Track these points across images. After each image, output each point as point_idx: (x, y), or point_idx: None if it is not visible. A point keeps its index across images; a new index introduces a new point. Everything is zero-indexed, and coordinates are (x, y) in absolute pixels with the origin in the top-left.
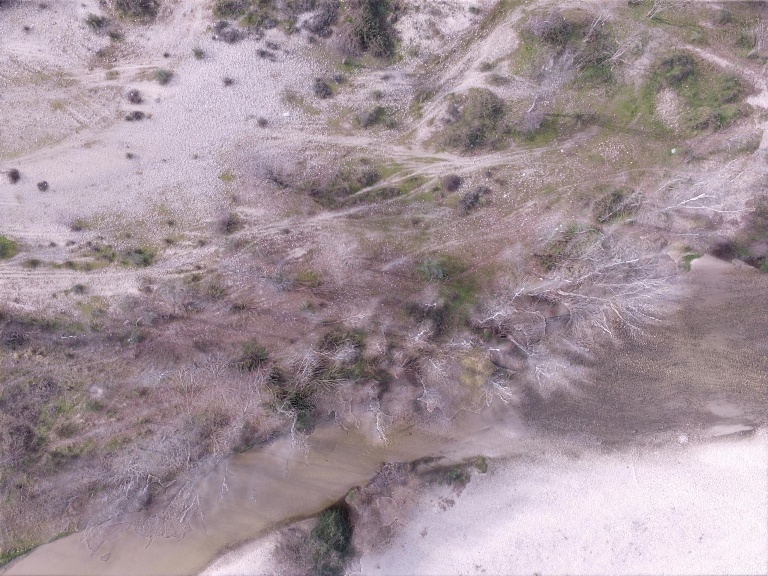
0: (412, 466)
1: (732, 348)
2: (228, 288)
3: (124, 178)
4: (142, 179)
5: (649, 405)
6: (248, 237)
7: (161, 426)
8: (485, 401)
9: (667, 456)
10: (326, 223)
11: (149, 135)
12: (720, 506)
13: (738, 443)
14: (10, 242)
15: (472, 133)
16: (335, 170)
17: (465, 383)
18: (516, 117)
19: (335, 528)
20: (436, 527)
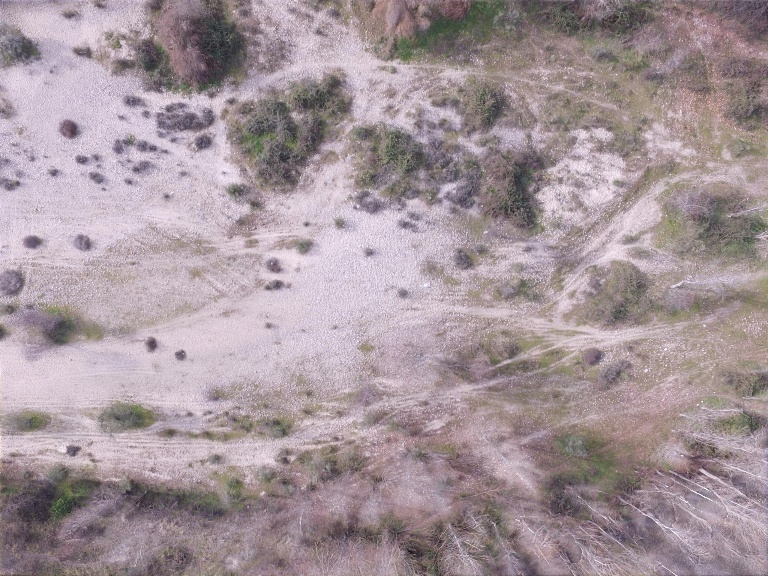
0: None
1: None
2: (365, 459)
3: (262, 348)
4: (281, 349)
5: None
6: (386, 408)
7: None
8: None
9: None
10: (465, 395)
11: (288, 305)
12: None
13: None
14: (147, 411)
15: (616, 310)
16: (475, 342)
17: None
18: (659, 291)
19: None
20: None
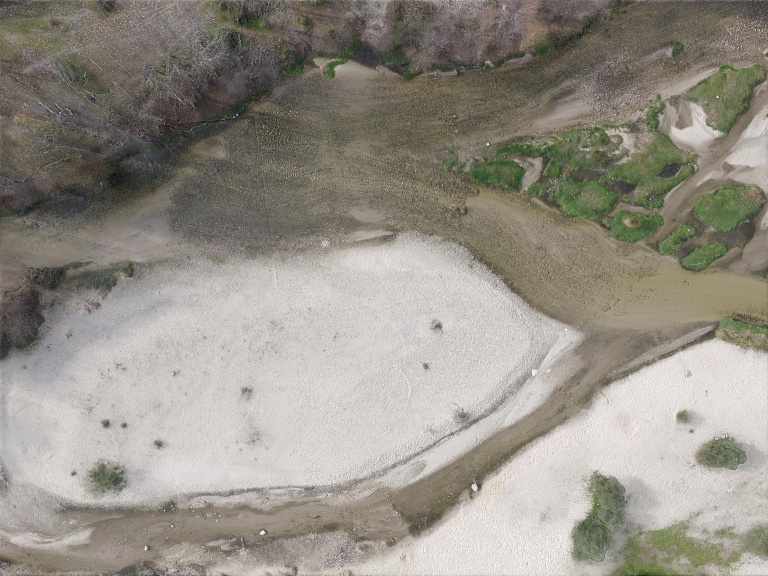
0: (59, 270)
1: (375, 155)
2: None
3: None
4: None
5: (293, 211)
6: None
7: None
8: None
9: (309, 260)
10: None
11: None
12: (355, 306)
13: (378, 247)
14: None
15: None
16: None
17: (10, 137)
18: None
19: None
20: (81, 328)
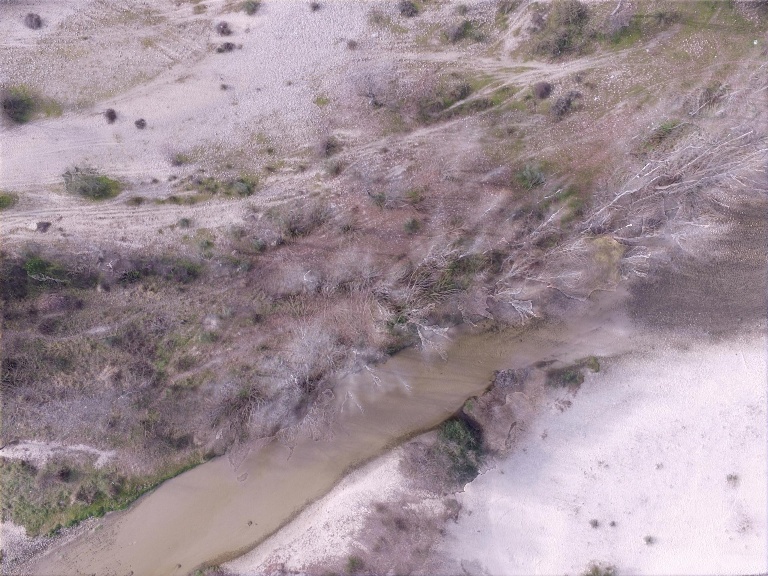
0: (526, 371)
1: None
2: (331, 211)
3: (220, 110)
4: (238, 109)
5: (751, 293)
6: (347, 159)
7: (277, 352)
8: (621, 276)
9: None
10: (423, 139)
11: (242, 65)
12: None
13: None
14: (112, 182)
15: (560, 38)
16: (427, 86)
17: (600, 260)
18: (600, 21)
19: (463, 432)
20: (555, 428)
